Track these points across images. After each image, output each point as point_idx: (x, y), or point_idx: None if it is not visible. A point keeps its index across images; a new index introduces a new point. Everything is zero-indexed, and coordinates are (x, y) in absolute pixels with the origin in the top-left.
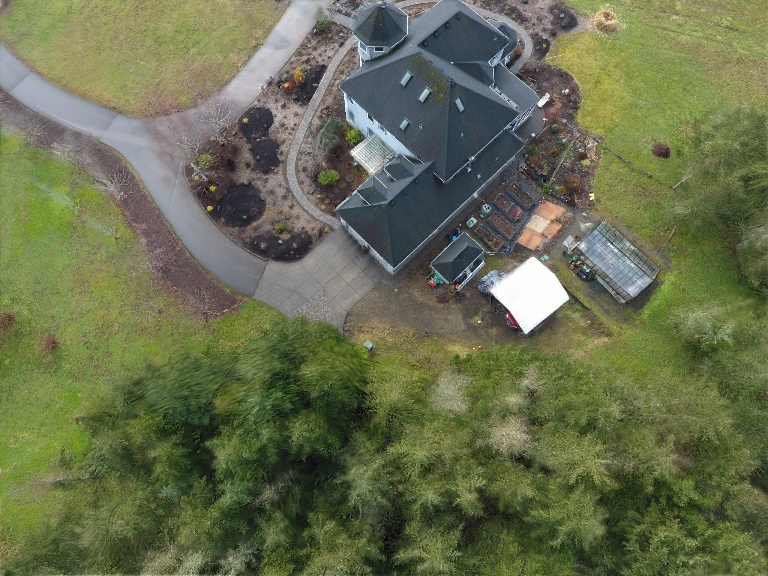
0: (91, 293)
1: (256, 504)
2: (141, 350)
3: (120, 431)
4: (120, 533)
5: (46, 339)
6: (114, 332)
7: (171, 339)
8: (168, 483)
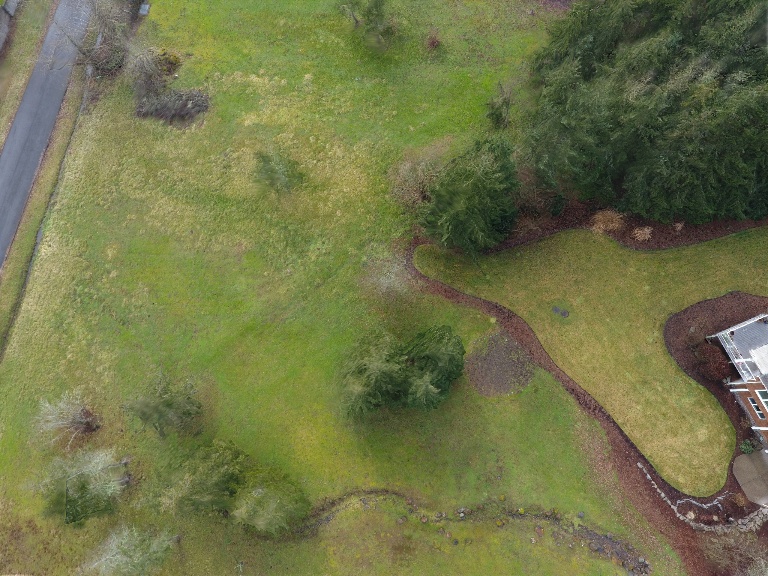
0: (465, 5)
1: (741, 50)
2: (520, 41)
3: (627, 1)
4: (648, 58)
5: (428, 41)
6: (492, 30)
7: (546, 31)
8: (673, 32)
